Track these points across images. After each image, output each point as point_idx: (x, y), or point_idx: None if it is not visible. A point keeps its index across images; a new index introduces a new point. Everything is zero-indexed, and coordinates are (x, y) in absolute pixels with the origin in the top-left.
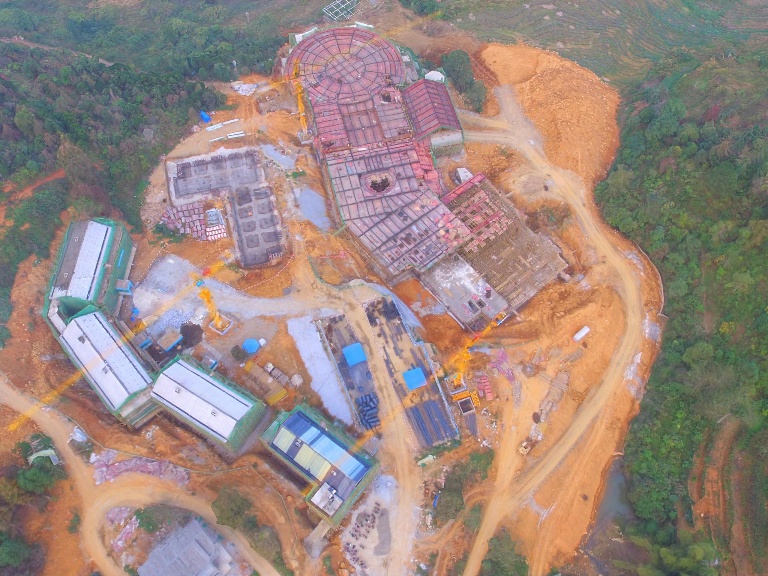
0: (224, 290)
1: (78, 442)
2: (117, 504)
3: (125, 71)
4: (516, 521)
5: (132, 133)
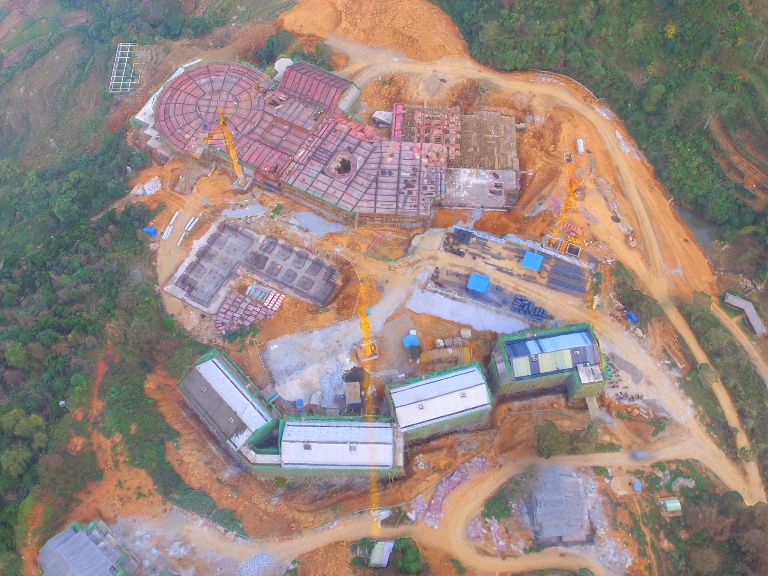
0: (339, 328)
1: (388, 518)
2: (465, 525)
3: (29, 256)
4: (676, 287)
5: (115, 289)
